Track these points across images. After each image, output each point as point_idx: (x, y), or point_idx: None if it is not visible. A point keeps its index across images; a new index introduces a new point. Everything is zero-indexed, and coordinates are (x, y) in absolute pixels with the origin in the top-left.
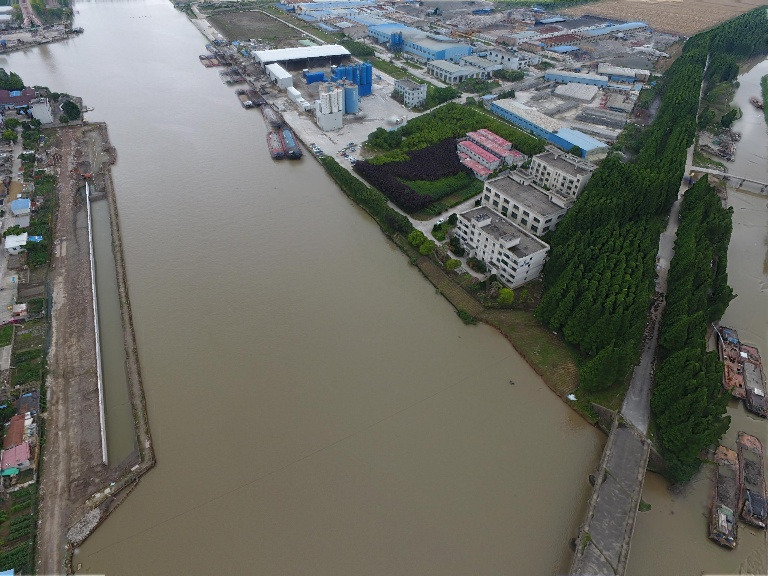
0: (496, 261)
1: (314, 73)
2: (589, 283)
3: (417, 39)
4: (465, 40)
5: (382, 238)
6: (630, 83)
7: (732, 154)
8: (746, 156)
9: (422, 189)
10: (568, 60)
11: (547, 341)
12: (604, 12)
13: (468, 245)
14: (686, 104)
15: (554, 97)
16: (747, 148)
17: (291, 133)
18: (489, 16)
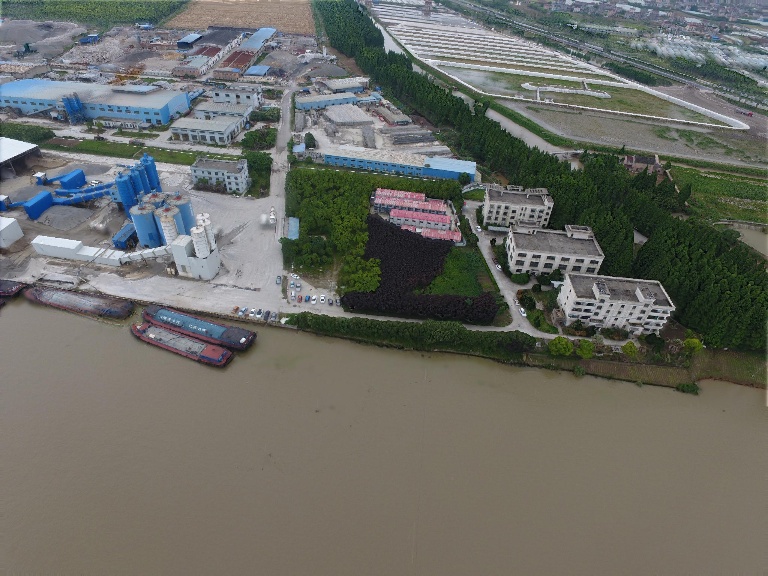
0: (636, 320)
1: (35, 198)
2: (731, 295)
3: (102, 97)
4: (138, 82)
5: (510, 370)
6: (362, 93)
7: (512, 135)
8: (515, 133)
9: (460, 289)
10: (282, 82)
11: (736, 360)
12: (207, 19)
13: (594, 321)
14: (461, 104)
15: (340, 127)
16: (503, 126)
17: (171, 311)
18: (109, 43)
